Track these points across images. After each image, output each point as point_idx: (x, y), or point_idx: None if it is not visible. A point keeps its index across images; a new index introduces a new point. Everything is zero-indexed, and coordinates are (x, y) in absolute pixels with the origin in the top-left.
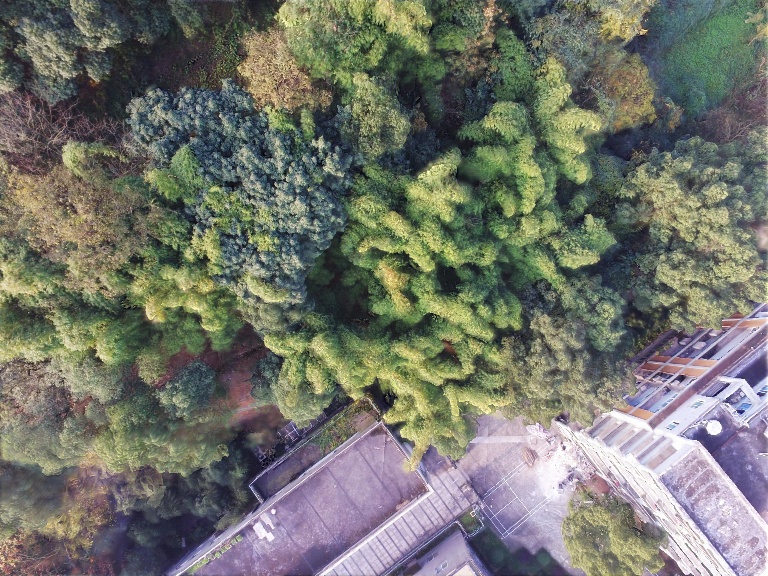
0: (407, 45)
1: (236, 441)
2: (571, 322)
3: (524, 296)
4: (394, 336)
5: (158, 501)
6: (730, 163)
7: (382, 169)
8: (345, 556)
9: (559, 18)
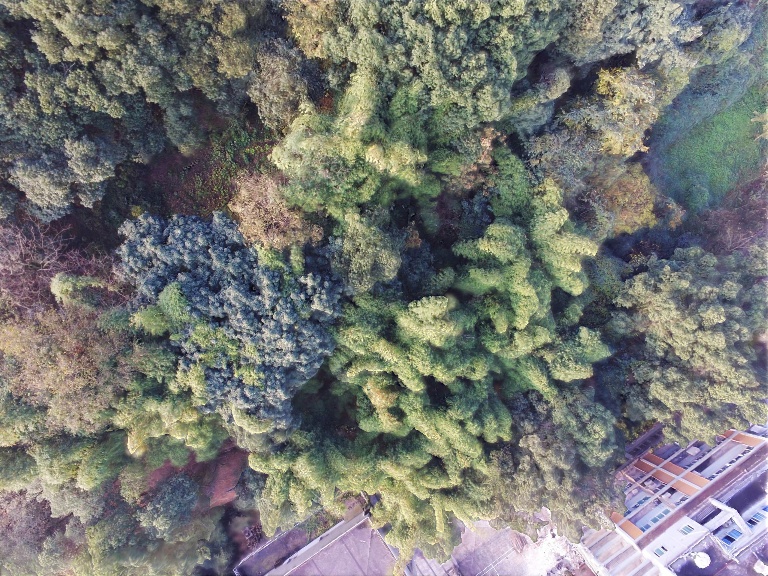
0: (401, 177)
1: (223, 521)
2: (561, 444)
3: (515, 406)
4: (381, 448)
5: None
6: (729, 282)
7: (372, 296)
8: None
9: (558, 140)
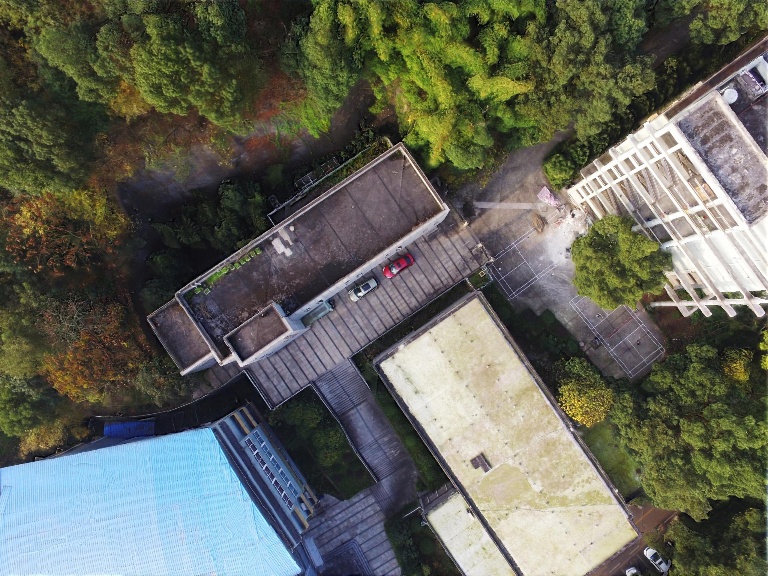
0: None
1: None
2: None
3: None
4: None
5: (184, 177)
6: None
7: None
8: (361, 267)
9: None
